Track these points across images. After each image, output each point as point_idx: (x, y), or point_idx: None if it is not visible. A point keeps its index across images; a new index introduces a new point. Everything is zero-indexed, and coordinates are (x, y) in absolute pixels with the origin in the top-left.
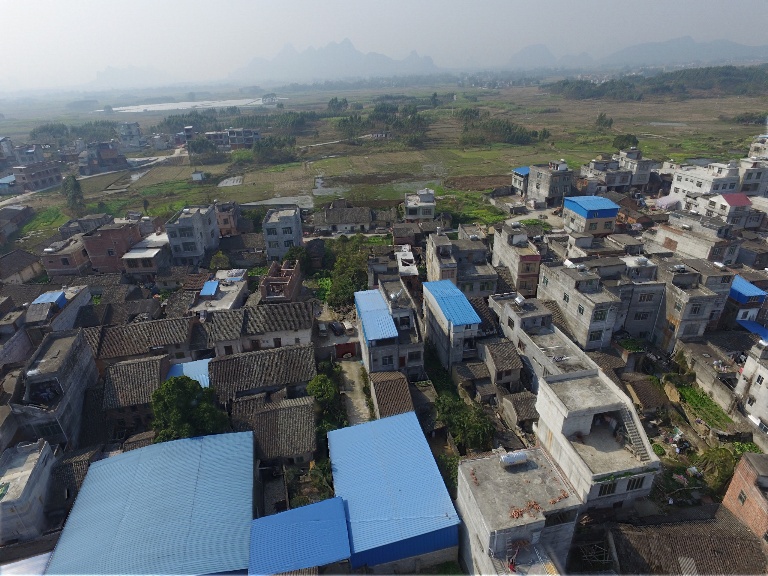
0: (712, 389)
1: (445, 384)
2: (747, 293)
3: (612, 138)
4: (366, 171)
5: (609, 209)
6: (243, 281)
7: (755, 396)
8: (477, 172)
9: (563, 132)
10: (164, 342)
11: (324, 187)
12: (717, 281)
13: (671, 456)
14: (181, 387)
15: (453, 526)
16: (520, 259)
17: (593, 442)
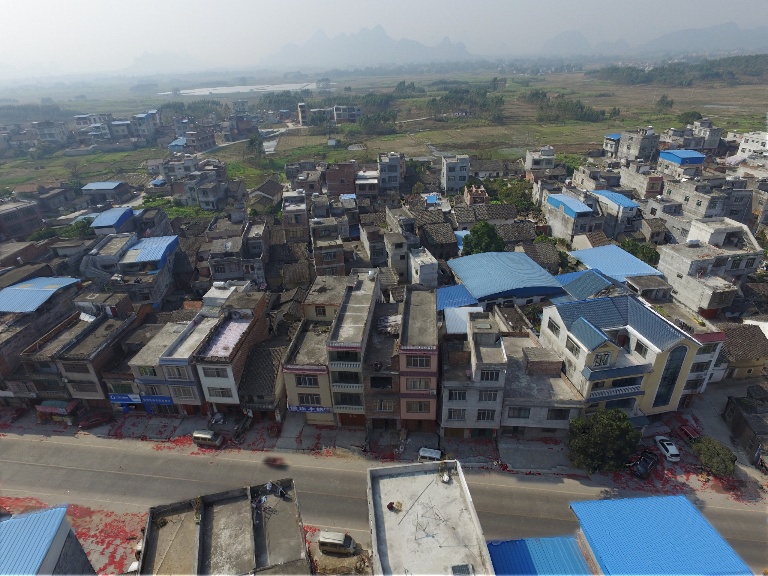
0: None
1: None
2: None
3: (673, 117)
4: (466, 140)
5: (698, 157)
6: (446, 198)
7: None
8: (563, 141)
9: (626, 112)
10: (431, 221)
11: (439, 151)
12: None
13: (761, 272)
14: (487, 226)
15: (660, 275)
16: (649, 180)
17: (725, 248)
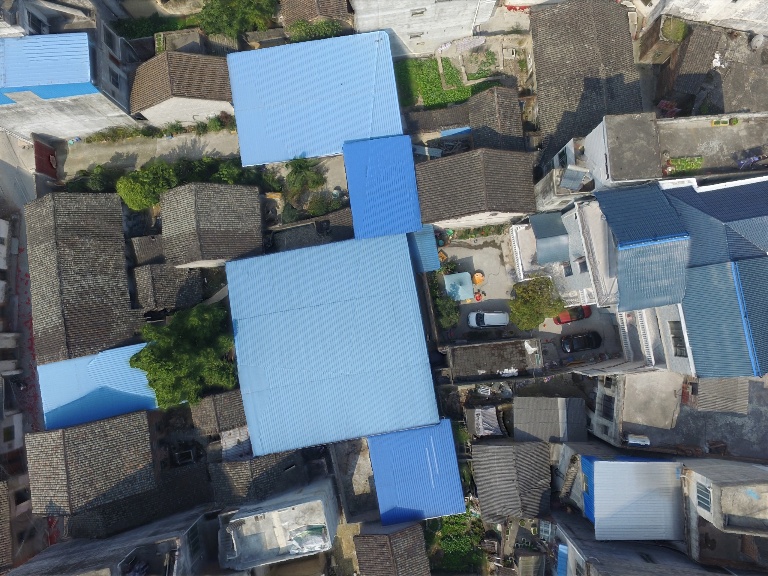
0: None
1: (145, 29)
2: None
3: None
4: None
5: None
6: None
7: None
8: None
9: None
10: None
11: None
12: None
13: None
14: (168, 352)
15: (388, 38)
16: None
17: None
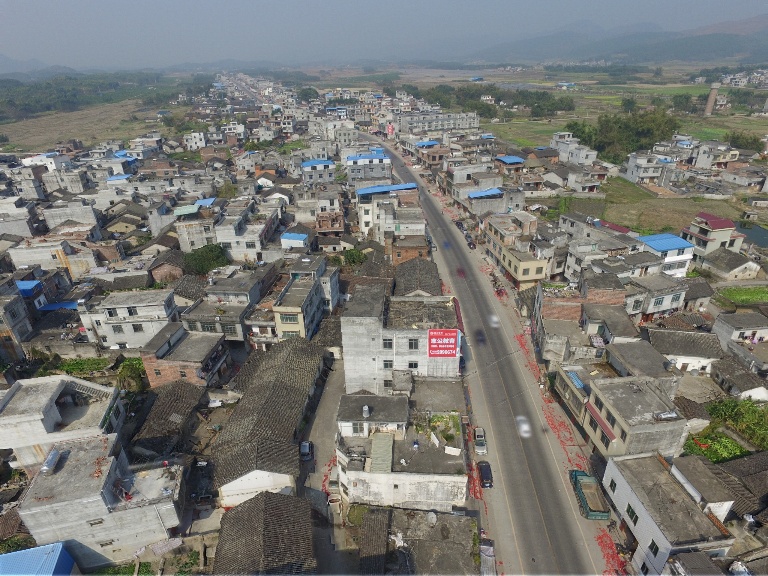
0: (77, 353)
1: None
2: (28, 287)
3: None
4: None
5: None
6: None
7: (104, 334)
8: None
9: None
10: None
11: None
12: (6, 288)
13: None
14: None
15: (61, 550)
16: None
17: (71, 419)
